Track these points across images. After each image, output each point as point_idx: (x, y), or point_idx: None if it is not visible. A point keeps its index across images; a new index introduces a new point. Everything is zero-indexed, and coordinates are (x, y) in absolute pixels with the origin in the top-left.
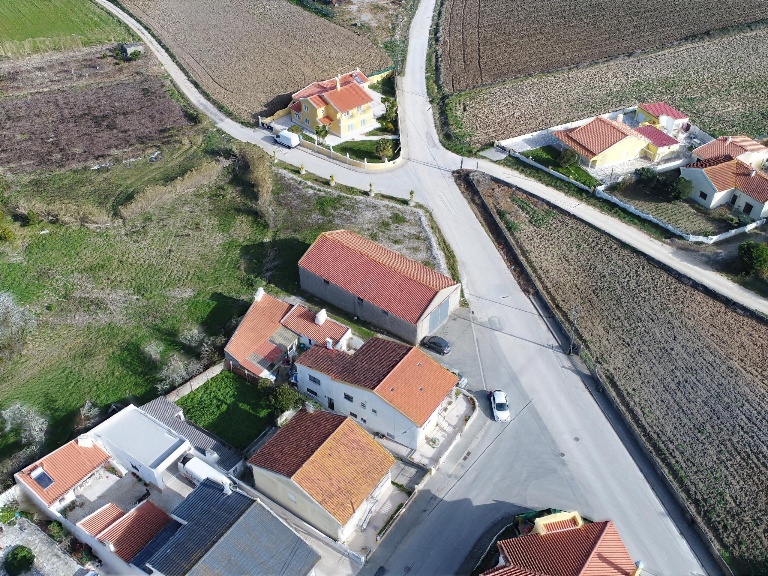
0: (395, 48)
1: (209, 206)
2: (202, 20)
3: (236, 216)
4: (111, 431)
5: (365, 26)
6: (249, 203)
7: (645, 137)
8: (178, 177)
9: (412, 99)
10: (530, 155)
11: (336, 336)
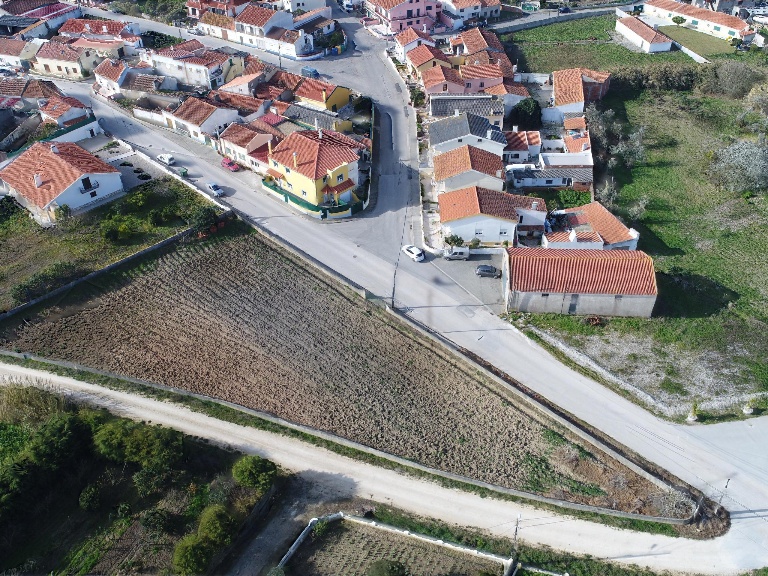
0: None
1: None
2: None
3: None
4: (585, 158)
5: None
6: None
7: None
8: None
9: None
10: None
11: (552, 237)
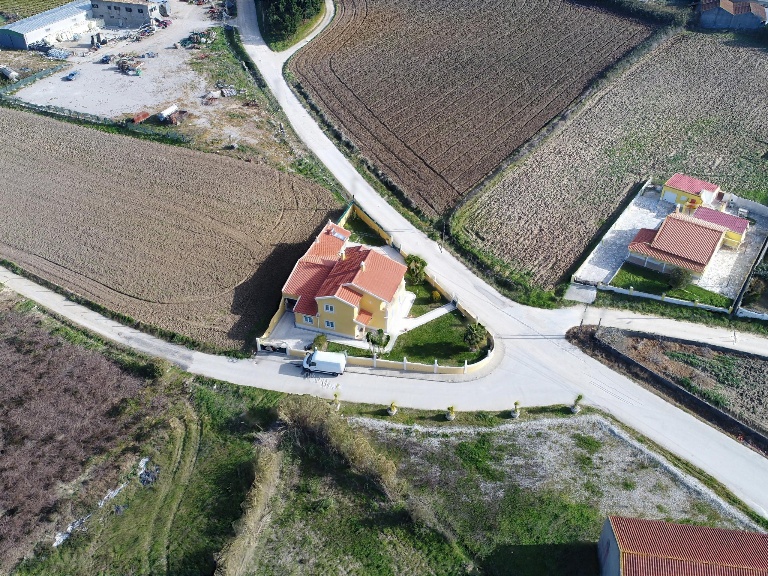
0: (313, 170)
1: (317, 536)
2: (1, 189)
3: (375, 537)
4: None
5: (244, 146)
6: (375, 504)
7: (718, 225)
8: (247, 510)
9: (408, 240)
10: (623, 283)
11: None
